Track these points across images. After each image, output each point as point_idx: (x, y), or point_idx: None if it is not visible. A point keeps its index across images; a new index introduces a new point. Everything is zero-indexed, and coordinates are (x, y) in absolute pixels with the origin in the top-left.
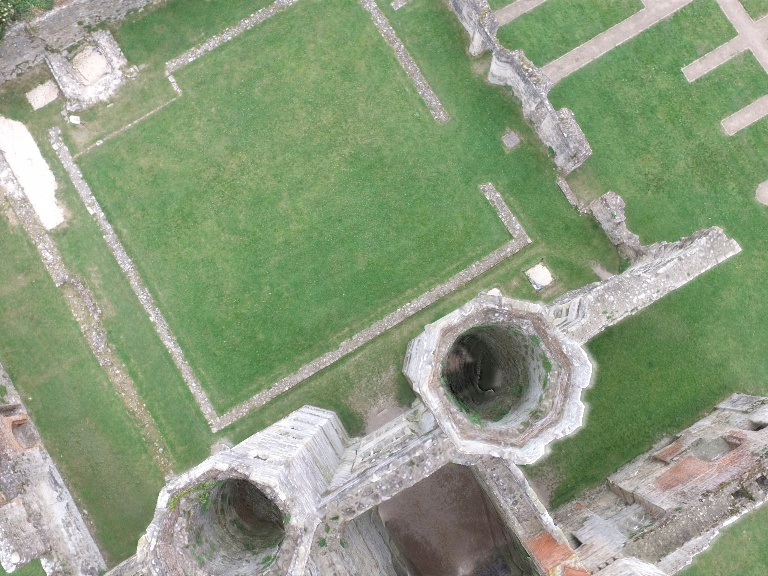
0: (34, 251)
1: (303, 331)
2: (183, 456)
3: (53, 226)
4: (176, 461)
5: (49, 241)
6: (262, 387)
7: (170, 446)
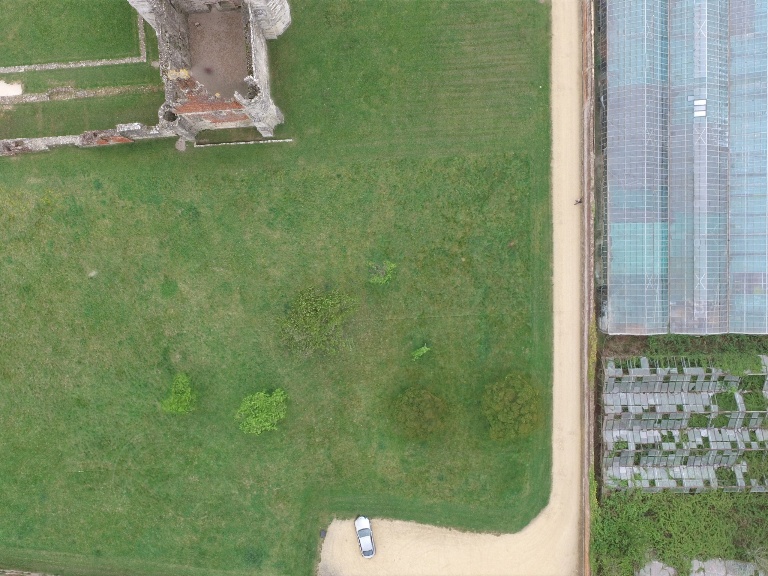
0: (29, 104)
1: (122, 2)
2: (150, 79)
3: (21, 91)
4: (151, 84)
5: (27, 95)
6: (137, 32)
7: (143, 83)
